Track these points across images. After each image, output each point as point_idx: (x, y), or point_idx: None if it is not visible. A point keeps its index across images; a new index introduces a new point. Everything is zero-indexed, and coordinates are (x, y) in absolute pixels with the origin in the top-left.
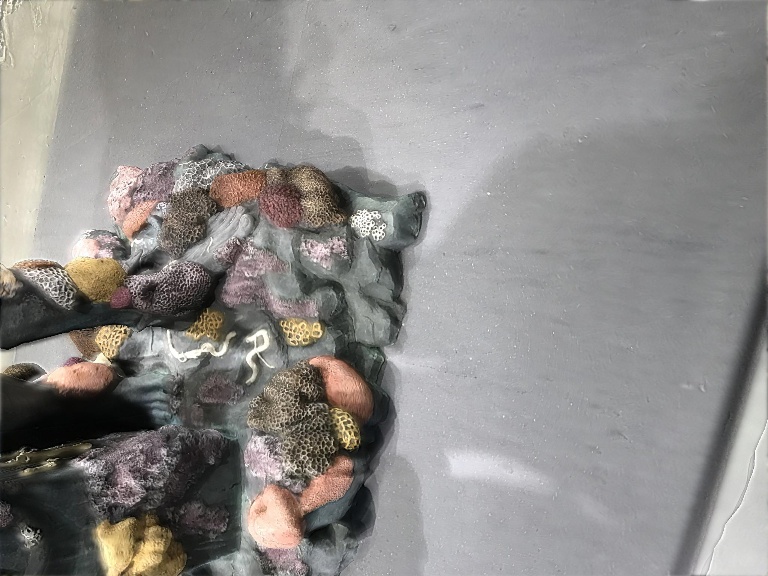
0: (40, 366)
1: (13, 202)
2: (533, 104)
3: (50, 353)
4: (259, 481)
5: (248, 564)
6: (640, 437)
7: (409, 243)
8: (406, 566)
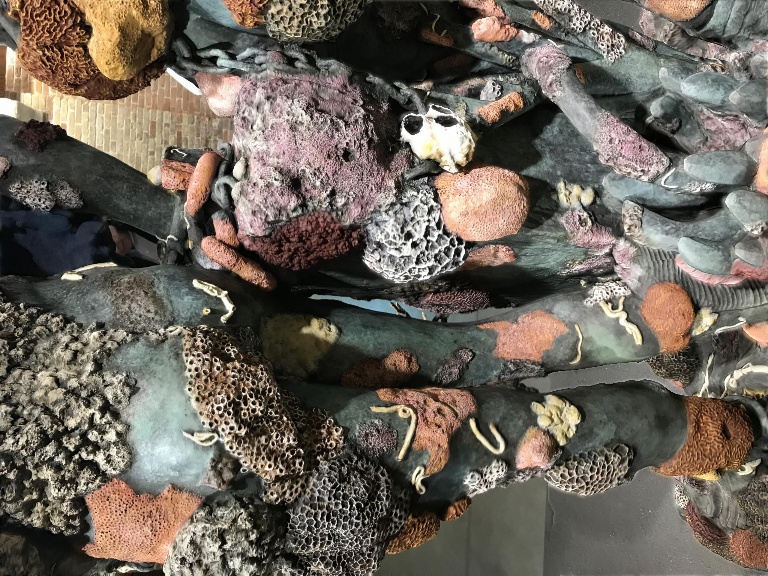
0: None
1: None
2: (640, 567)
3: None
4: None
5: None
6: (570, 373)
7: None
8: None
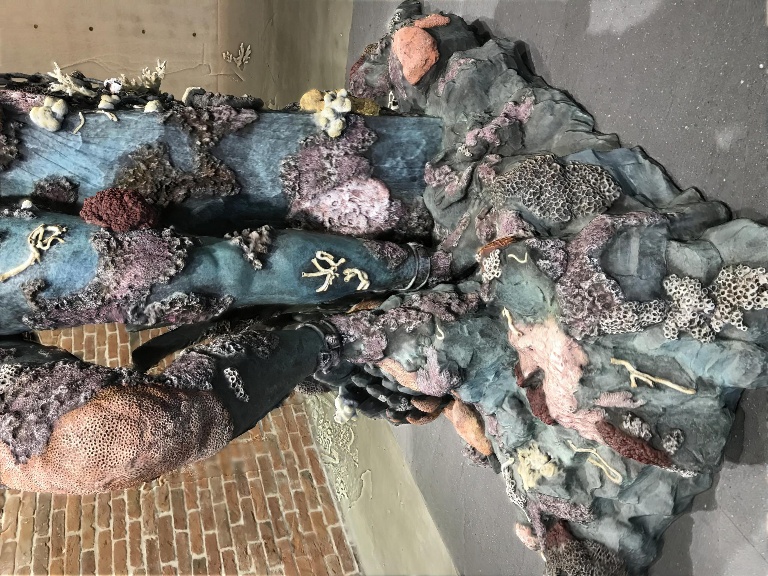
0: (430, 461)
1: (397, 484)
2: None
3: (427, 440)
4: (402, 72)
5: (444, 105)
6: None
7: (418, 6)
8: (545, 4)
